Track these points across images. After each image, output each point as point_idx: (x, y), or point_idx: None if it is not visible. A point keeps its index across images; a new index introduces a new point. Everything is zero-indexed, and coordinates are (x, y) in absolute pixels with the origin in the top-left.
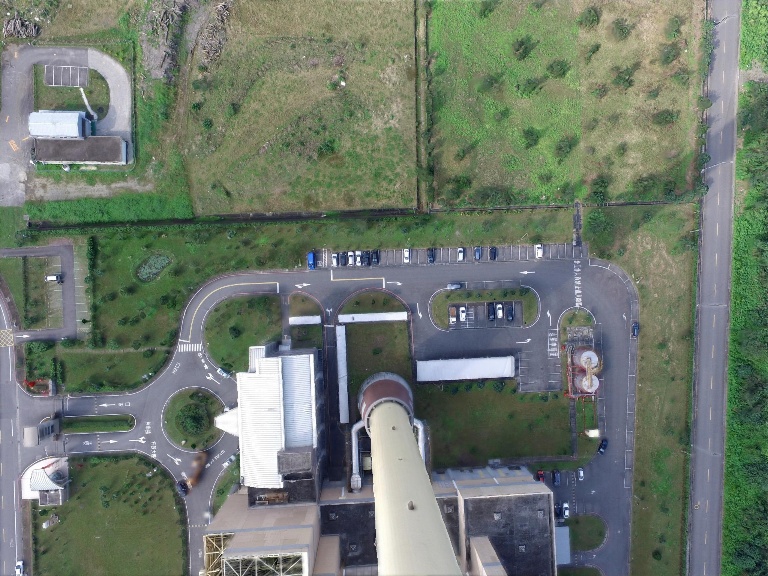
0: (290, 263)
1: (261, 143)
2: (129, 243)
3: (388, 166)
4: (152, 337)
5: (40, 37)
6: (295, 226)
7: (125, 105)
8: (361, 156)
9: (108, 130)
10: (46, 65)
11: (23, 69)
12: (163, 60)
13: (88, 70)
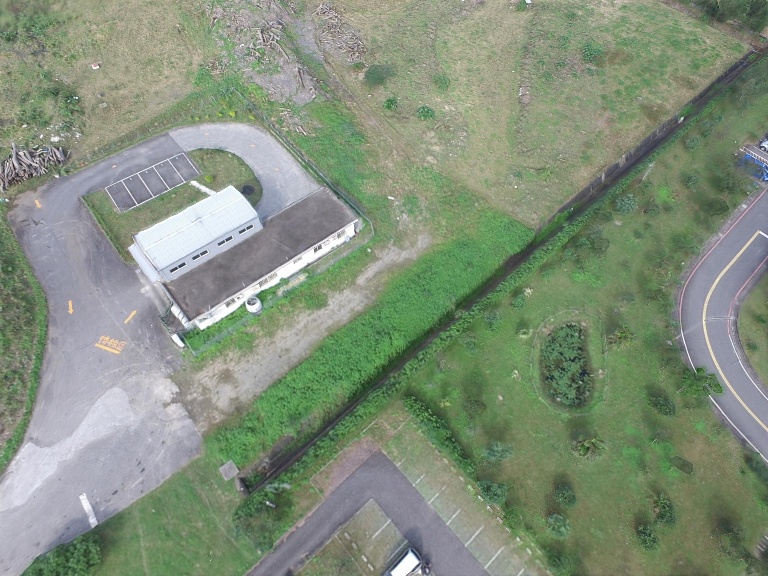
0: (750, 181)
1: (513, 95)
2: (483, 352)
3: (673, 31)
4: (730, 515)
5: (72, 160)
6: (674, 148)
7: (283, 162)
8: (636, 39)
9: (282, 208)
10: (106, 187)
11: (63, 215)
12: (300, 78)
13: (186, 155)
